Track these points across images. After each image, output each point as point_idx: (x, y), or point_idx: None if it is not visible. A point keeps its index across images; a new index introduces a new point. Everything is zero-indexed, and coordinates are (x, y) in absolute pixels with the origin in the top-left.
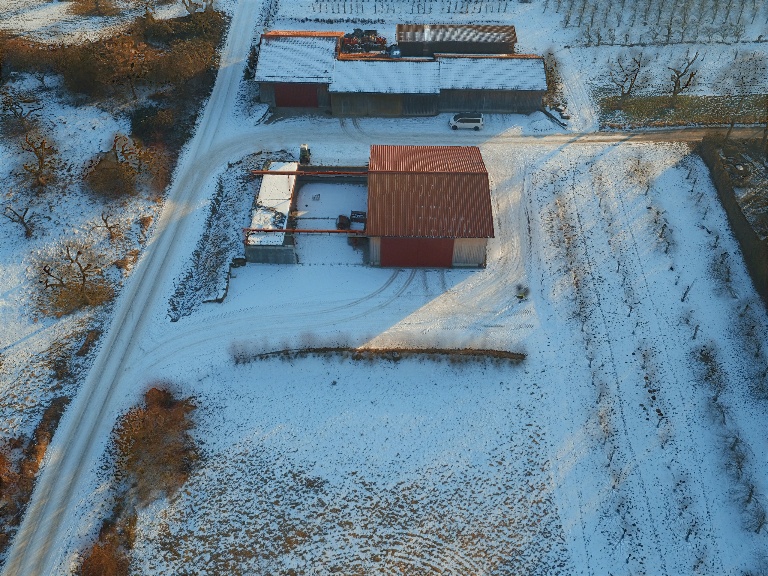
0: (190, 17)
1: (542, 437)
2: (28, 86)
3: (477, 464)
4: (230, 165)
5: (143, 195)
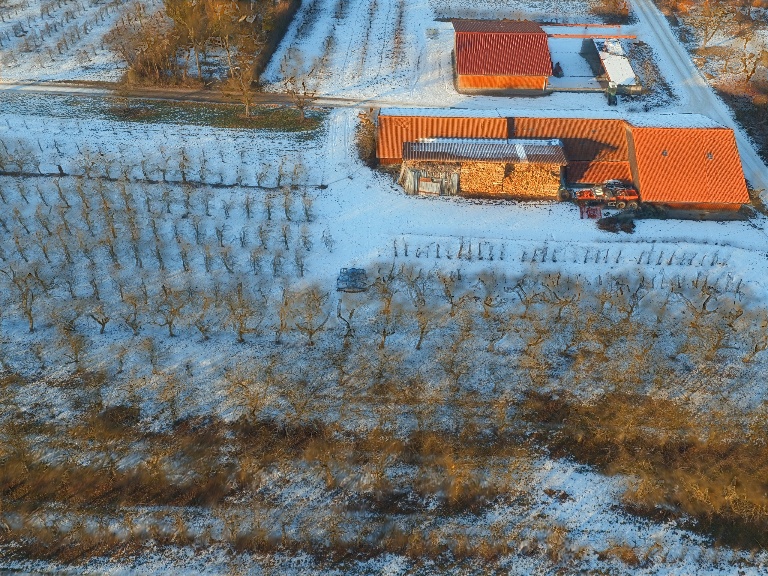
0: None
1: (430, 8)
2: None
3: (461, 6)
4: None
5: None
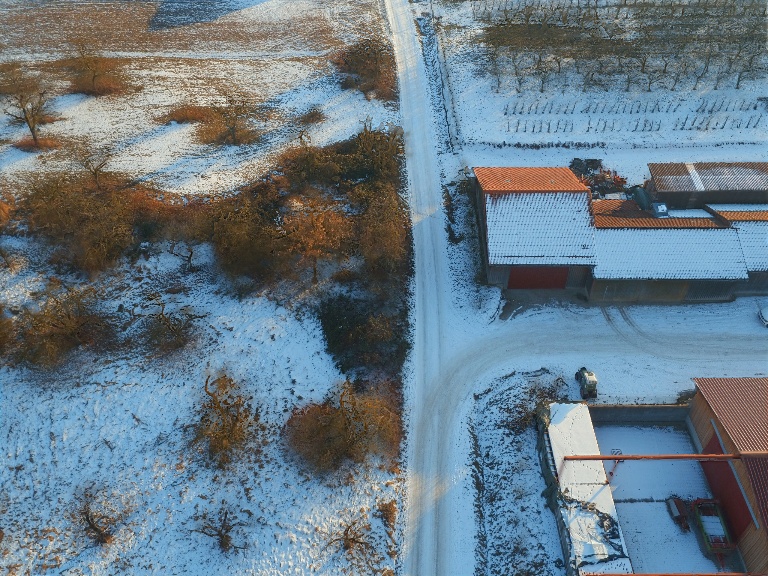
0: (355, 145)
1: None
2: (167, 265)
3: None
4: (476, 396)
5: (372, 460)
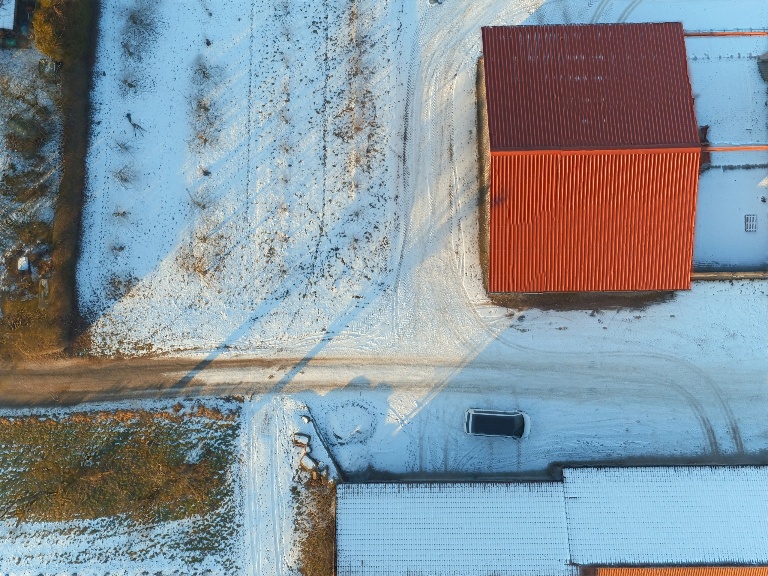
0: None
1: None
2: None
3: None
4: None
5: None
